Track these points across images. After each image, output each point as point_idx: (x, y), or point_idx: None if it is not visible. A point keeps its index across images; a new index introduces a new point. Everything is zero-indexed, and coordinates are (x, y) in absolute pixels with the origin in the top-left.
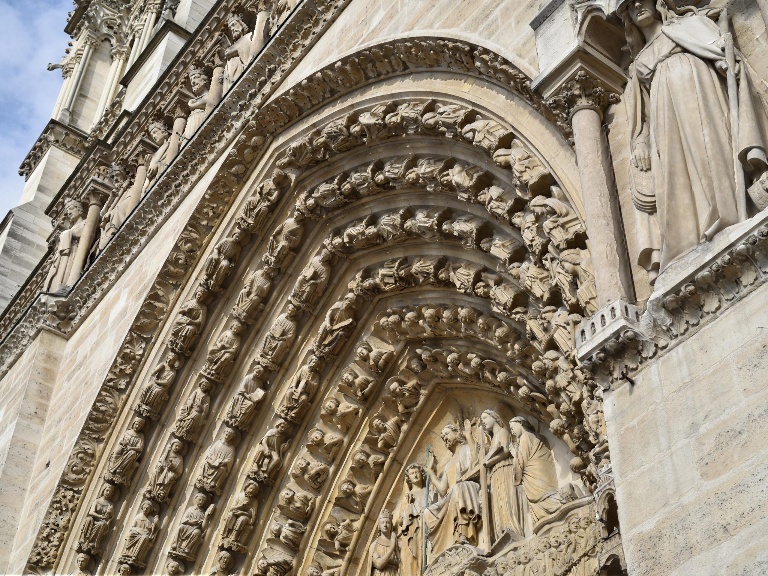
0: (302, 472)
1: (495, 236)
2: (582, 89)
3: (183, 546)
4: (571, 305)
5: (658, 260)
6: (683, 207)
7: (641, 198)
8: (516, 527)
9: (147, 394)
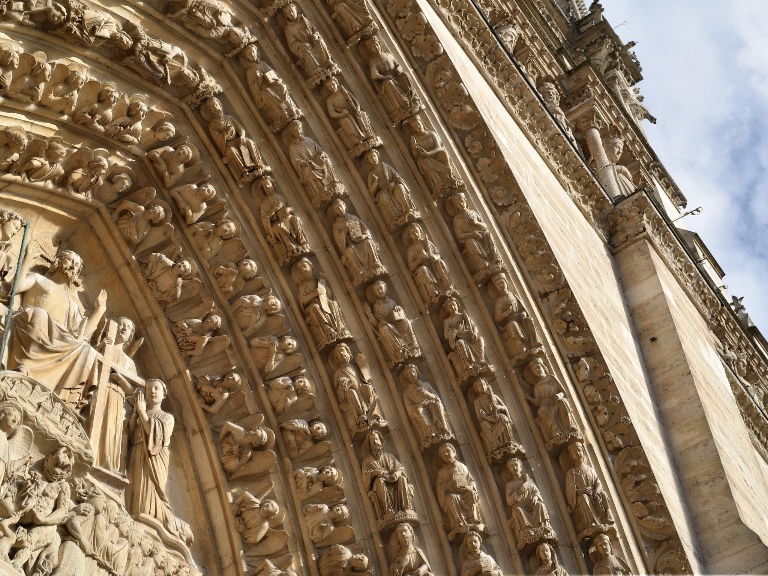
0: (3, 61)
1: None
2: None
3: None
4: None
5: None
6: None
7: None
8: None
9: None
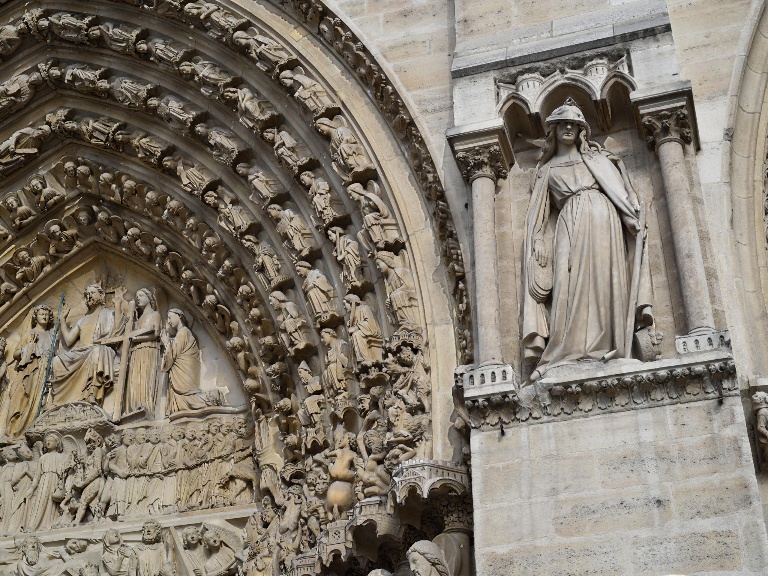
0: None
1: (259, 168)
2: (490, 159)
3: None
4: (354, 286)
5: (541, 345)
6: (582, 321)
7: (537, 288)
8: (150, 407)
9: None
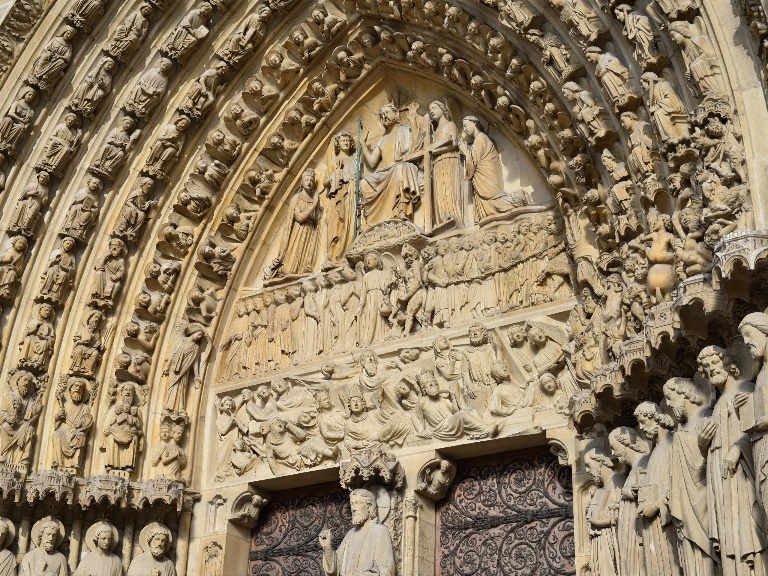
0: (235, 117)
1: None
2: None
3: (107, 165)
4: (650, 63)
5: None
6: None
7: None
8: (459, 216)
9: (84, 5)
